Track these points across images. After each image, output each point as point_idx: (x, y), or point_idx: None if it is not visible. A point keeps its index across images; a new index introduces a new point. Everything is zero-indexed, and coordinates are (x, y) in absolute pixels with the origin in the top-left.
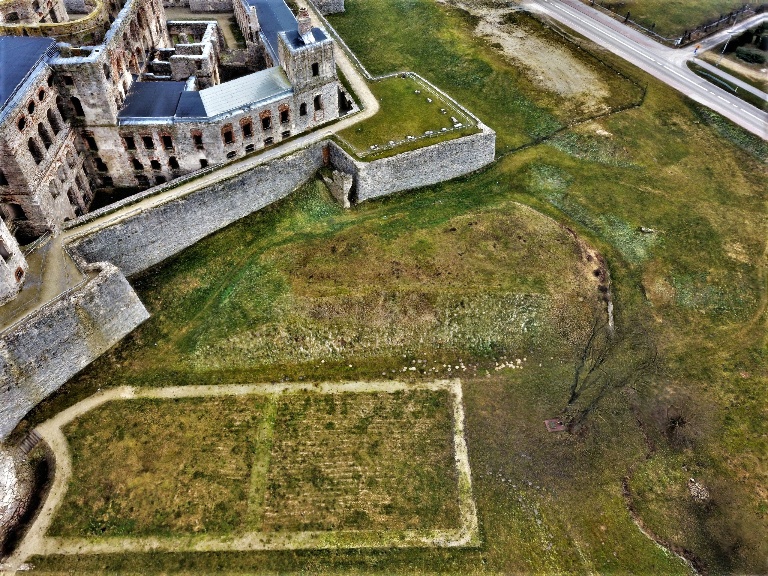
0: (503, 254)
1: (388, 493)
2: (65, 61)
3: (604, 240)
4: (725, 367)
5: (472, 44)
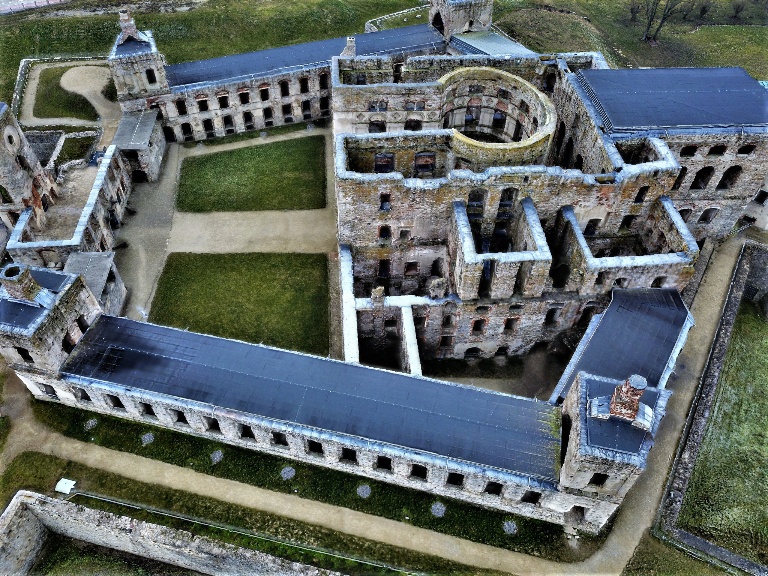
0: (555, 30)
1: None
2: (607, 66)
3: (512, 8)
4: (586, 1)
5: (289, 3)
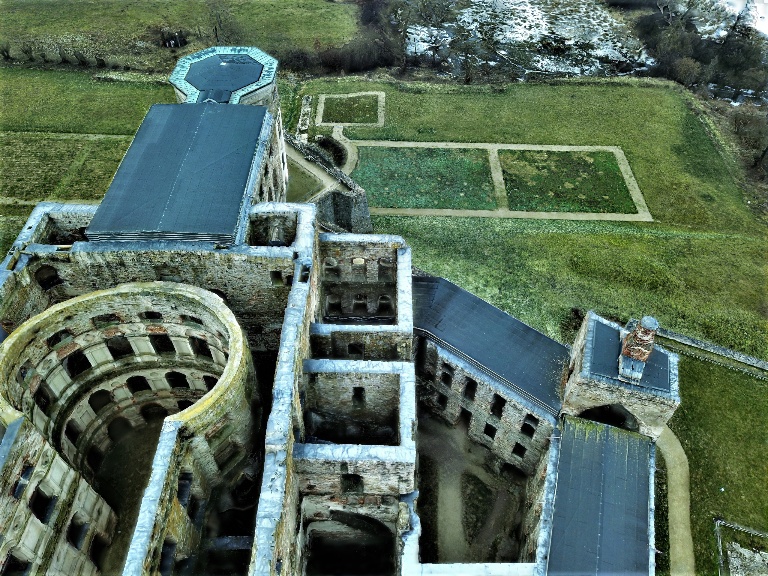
0: None
1: (4, 149)
2: (78, 206)
3: None
4: None
5: None
